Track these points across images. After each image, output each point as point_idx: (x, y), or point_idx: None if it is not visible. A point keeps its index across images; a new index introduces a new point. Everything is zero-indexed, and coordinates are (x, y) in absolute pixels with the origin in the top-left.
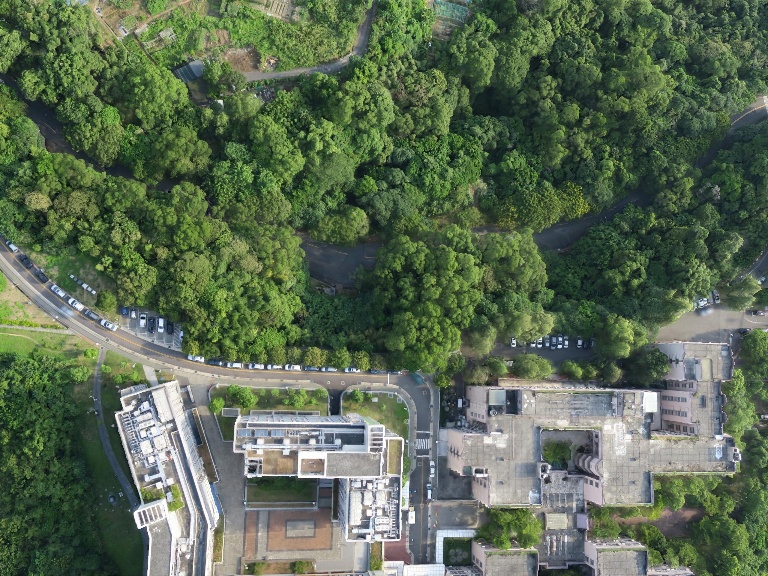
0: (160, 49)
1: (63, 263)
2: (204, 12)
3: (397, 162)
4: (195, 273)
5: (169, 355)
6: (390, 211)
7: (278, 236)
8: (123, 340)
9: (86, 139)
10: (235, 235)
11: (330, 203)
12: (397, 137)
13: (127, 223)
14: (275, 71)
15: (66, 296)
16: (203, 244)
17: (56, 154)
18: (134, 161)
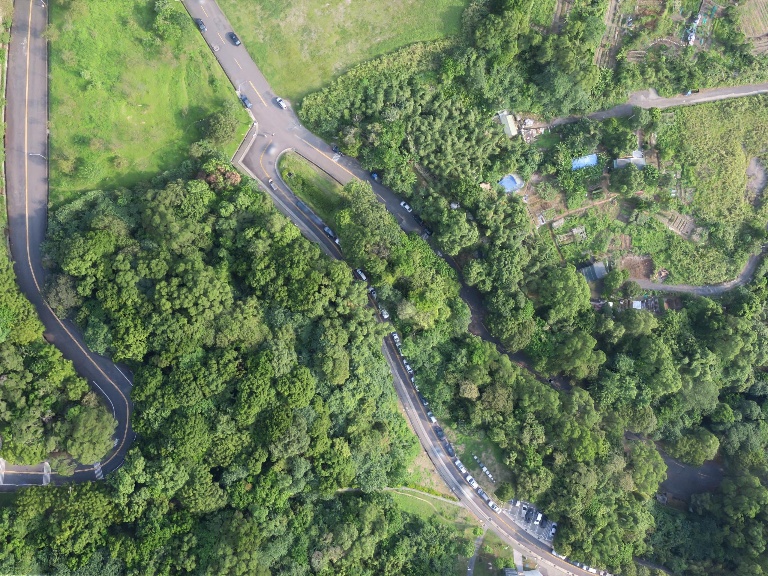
0: (568, 243)
1: (470, 443)
2: (614, 215)
3: (754, 394)
4: (587, 488)
5: (536, 545)
6: (738, 441)
7: (652, 459)
8: (502, 523)
9: (507, 330)
10: (609, 444)
11: (687, 422)
12: (757, 368)
13: (537, 426)
14: (663, 283)
15: (466, 472)
16: (593, 458)
17: (478, 337)
18: (539, 356)
